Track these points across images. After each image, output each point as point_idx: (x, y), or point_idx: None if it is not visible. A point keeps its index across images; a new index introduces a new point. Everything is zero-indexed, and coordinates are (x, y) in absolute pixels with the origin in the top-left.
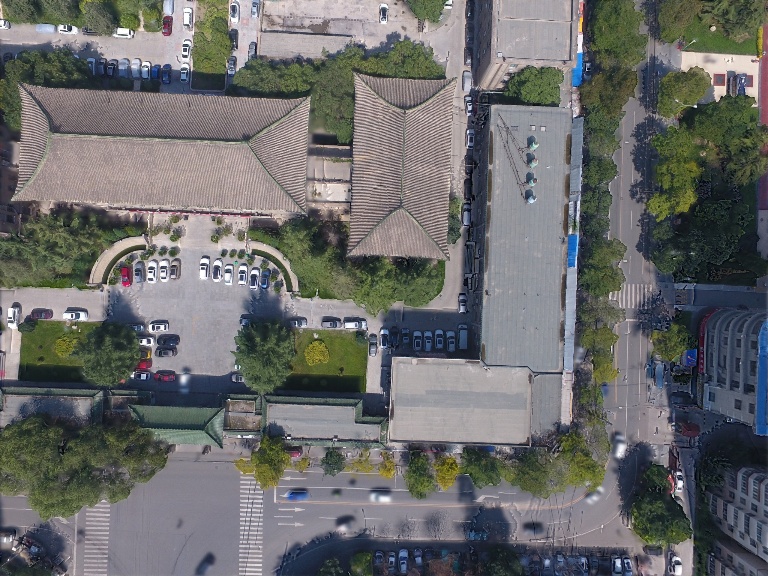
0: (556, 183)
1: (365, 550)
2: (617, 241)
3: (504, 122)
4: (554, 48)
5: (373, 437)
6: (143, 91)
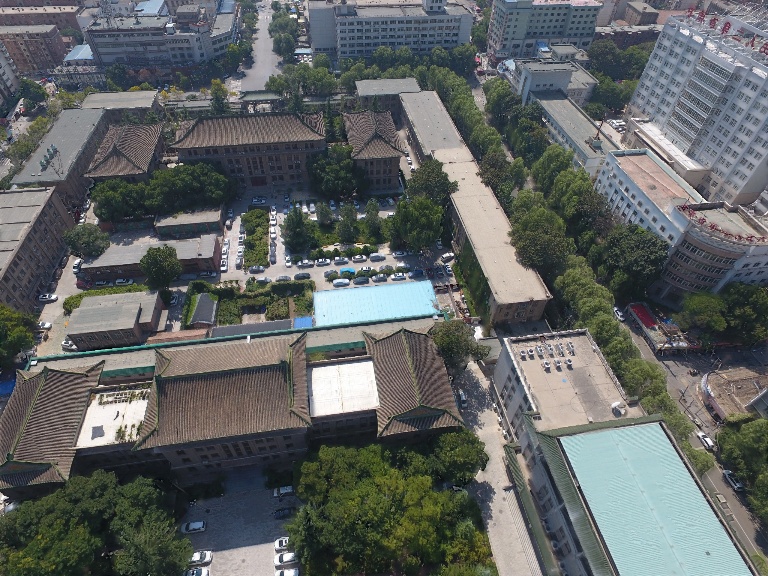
0: (36, 158)
1: (184, 89)
2: (8, 152)
3: (58, 175)
4: (8, 198)
5: (171, 103)
6: (299, 201)
